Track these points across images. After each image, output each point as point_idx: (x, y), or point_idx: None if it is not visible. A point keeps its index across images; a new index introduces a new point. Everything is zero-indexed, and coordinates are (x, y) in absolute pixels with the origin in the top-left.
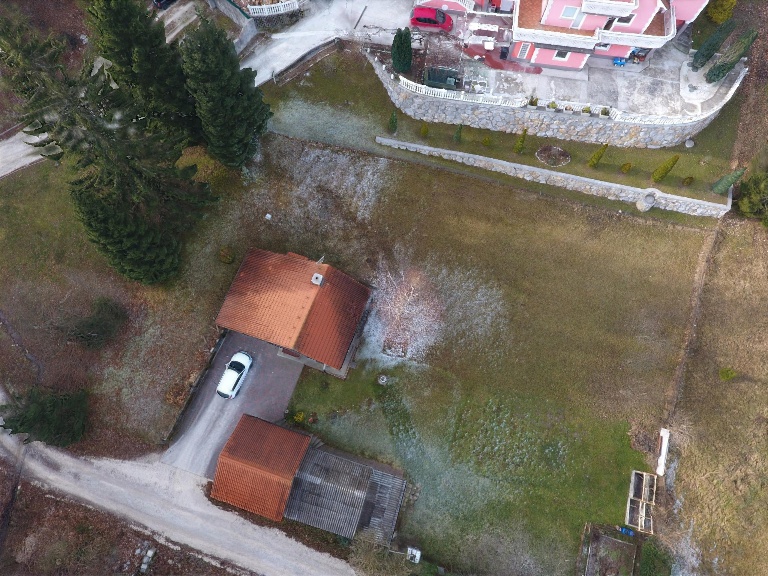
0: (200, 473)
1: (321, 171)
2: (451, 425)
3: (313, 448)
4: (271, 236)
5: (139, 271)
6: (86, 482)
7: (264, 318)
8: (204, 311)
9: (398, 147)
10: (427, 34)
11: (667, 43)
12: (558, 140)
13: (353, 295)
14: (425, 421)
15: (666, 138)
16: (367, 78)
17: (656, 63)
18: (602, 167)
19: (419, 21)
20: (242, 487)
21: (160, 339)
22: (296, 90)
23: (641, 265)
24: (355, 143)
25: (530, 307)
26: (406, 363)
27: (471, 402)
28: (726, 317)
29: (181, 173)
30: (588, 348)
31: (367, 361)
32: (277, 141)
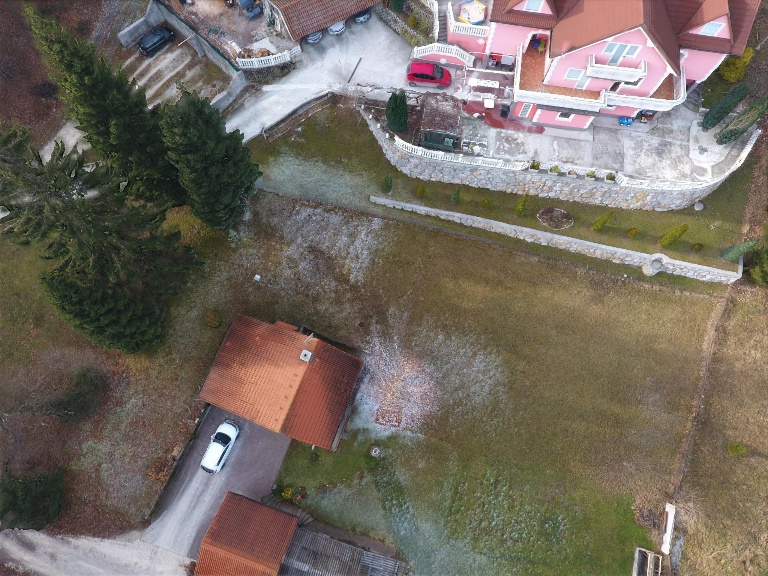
0: (183, 553)
1: (312, 231)
2: (447, 499)
3: (301, 528)
4: (260, 298)
5: (119, 344)
6: (63, 563)
7: (250, 395)
8: (189, 379)
9: (393, 206)
10: (424, 94)
11: None
12: (561, 201)
13: (344, 369)
14: (419, 495)
15: (674, 202)
16: (361, 135)
17: (664, 122)
18: (607, 230)
19: (416, 77)
20: (225, 575)
21: (142, 410)
22: (287, 146)
23: (647, 332)
24: (348, 202)
25: (530, 374)
26: (400, 433)
27: (468, 474)
28: (736, 388)
29: (163, 243)
30: (591, 417)
31: (359, 431)
32: (267, 199)
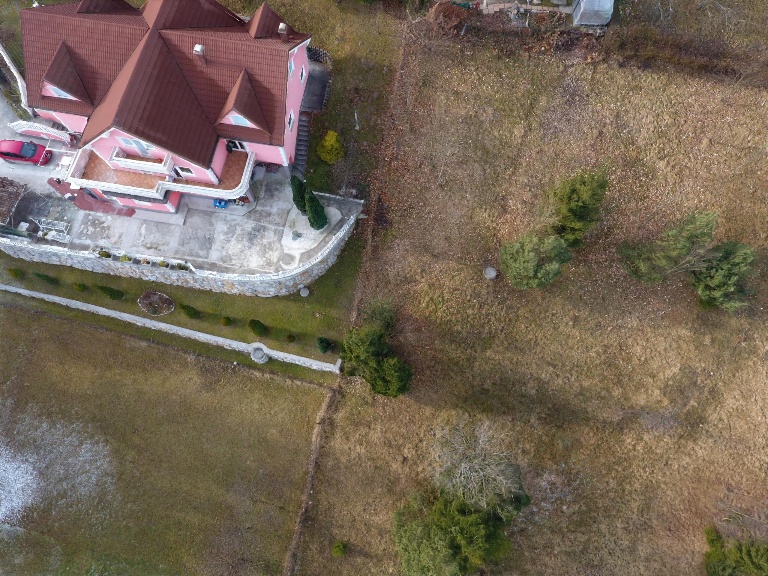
0: None
1: None
2: None
3: None
4: None
5: None
6: None
7: None
8: None
9: None
10: None
11: (283, 180)
12: (165, 285)
13: None
14: None
15: (269, 289)
16: None
17: (264, 205)
18: (207, 317)
19: (4, 155)
20: None
21: None
22: None
23: (259, 422)
24: None
25: (140, 465)
26: None
27: (70, 569)
28: (342, 485)
29: None
30: (206, 510)
31: None
32: None
